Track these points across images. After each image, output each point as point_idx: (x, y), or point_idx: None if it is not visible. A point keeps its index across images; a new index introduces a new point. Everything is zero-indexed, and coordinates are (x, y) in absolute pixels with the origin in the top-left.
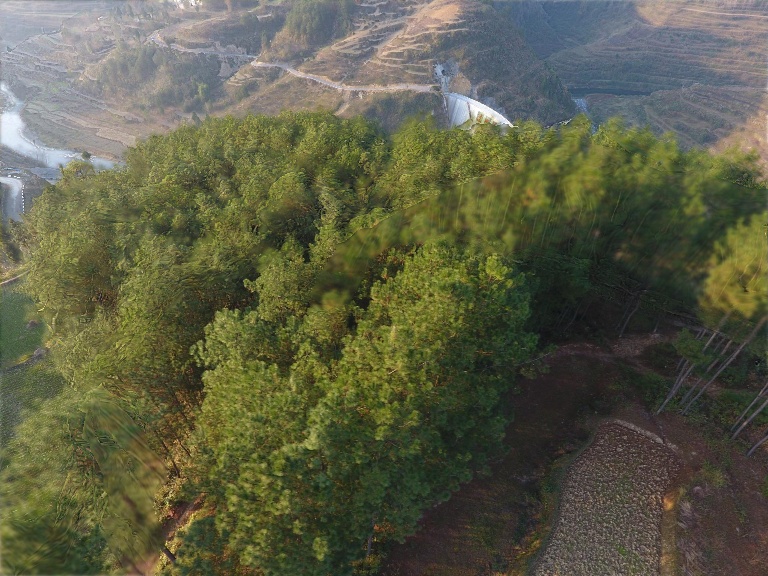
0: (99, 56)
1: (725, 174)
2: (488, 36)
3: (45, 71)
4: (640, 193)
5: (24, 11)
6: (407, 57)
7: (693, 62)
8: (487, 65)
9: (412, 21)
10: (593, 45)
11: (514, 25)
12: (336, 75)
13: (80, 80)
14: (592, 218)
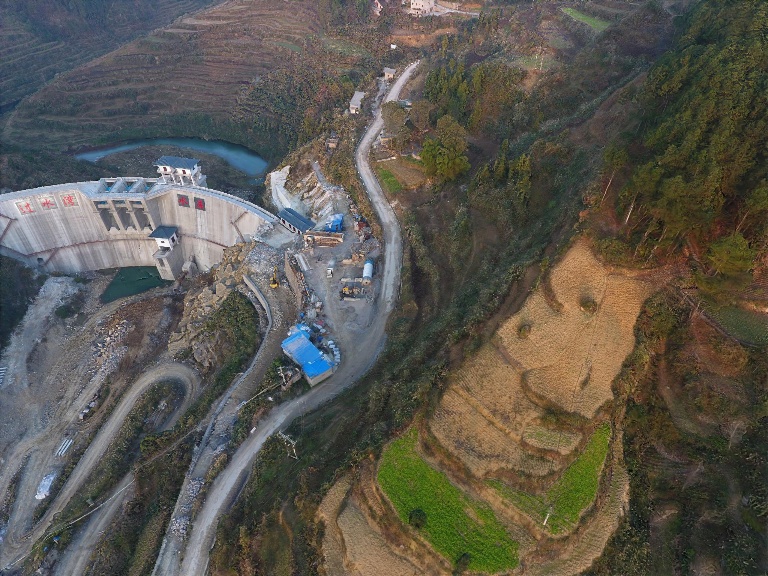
0: None
1: (206, 119)
2: None
3: None
4: None
5: None
6: None
7: None
8: None
9: None
10: None
11: None
12: None
13: None
14: None
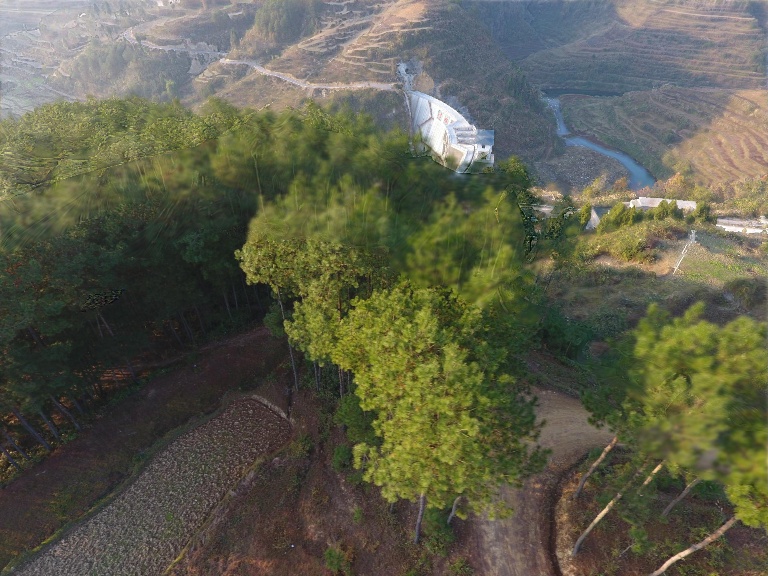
0: (75, 52)
1: (684, 175)
2: (453, 35)
3: (21, 67)
4: (401, 180)
5: (8, 8)
6: (371, 55)
7: (669, 63)
8: (451, 64)
9: (379, 20)
10: (571, 46)
11: (481, 24)
12: (301, 73)
13: (53, 76)
14: (363, 205)
